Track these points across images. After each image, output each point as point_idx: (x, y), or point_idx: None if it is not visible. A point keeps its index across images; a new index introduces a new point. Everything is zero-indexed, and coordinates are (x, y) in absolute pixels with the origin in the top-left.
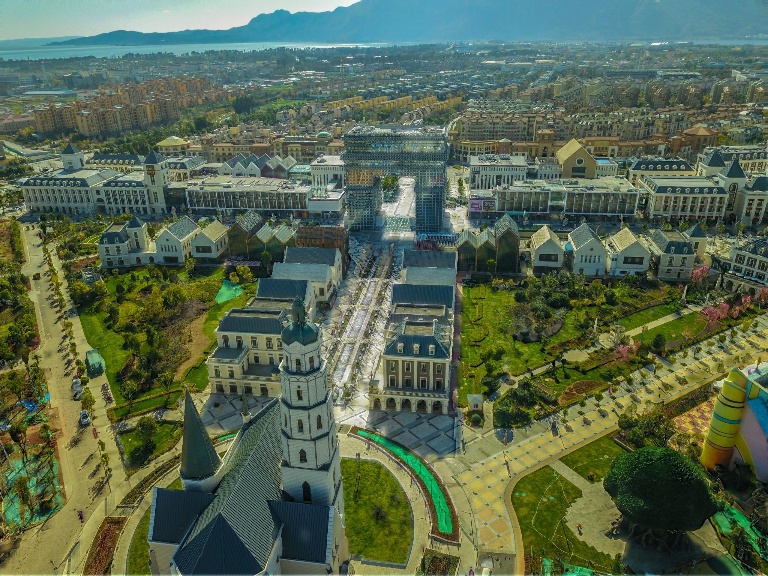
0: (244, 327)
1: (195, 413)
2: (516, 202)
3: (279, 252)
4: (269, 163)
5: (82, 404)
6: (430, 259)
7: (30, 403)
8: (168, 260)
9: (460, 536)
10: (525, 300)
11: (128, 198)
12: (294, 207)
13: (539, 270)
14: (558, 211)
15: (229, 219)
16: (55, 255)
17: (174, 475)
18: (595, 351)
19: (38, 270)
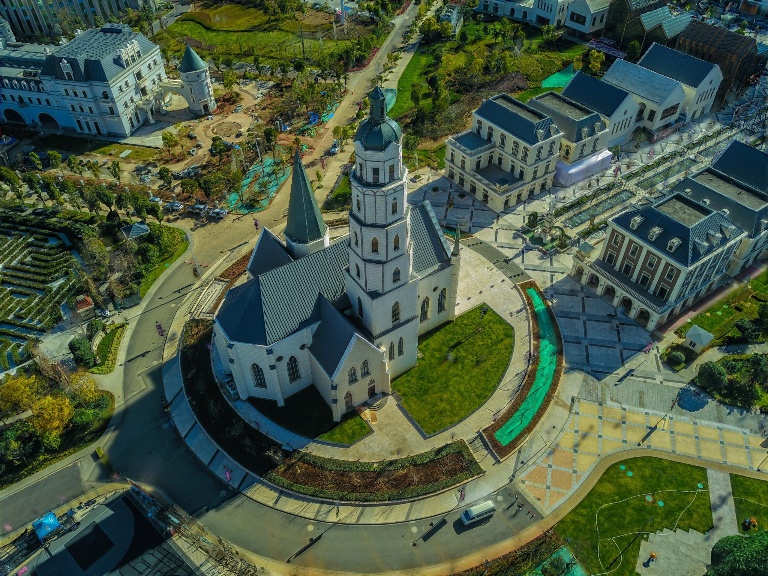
0: (499, 119)
1: (300, 176)
2: None
3: None
4: None
5: (334, 134)
6: None
7: (315, 116)
8: (540, 21)
9: (509, 455)
10: None
11: None
12: None
13: None
14: None
15: None
16: None
17: (344, 231)
18: None
19: None
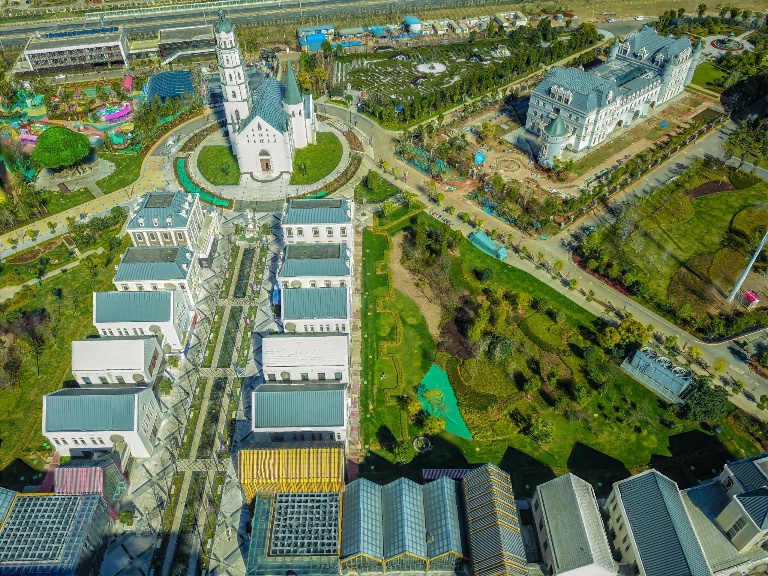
0: None
1: None
2: None
3: None
4: None
5: None
6: (97, 392)
7: None
8: None
9: None
10: None
11: None
12: None
13: None
14: None
15: None
16: None
17: (340, 169)
18: None
19: None
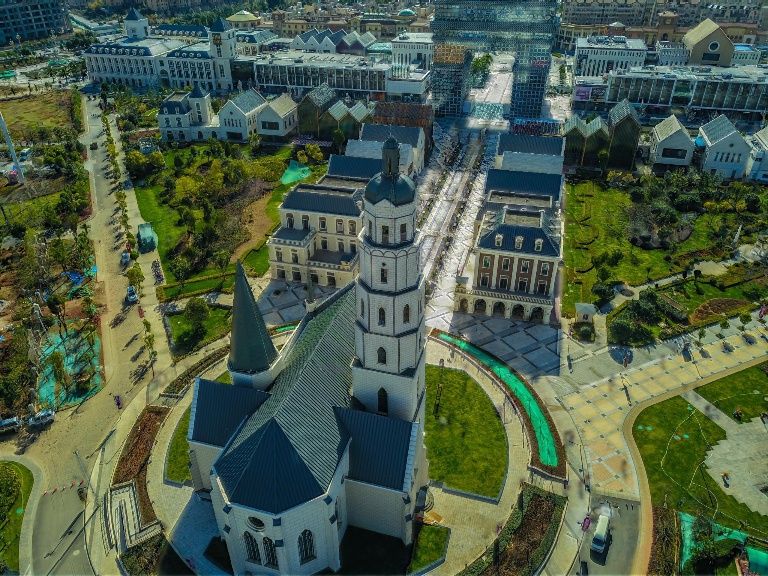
0: (312, 205)
1: (247, 291)
2: (632, 90)
3: (353, 132)
4: (345, 39)
5: (129, 279)
6: (531, 145)
7: (76, 275)
8: (232, 137)
9: (568, 471)
10: (643, 200)
11: (193, 71)
12: (371, 88)
13: (660, 168)
14: (682, 104)
15: (299, 99)
16: (115, 126)
17: (225, 366)
18: (736, 264)
19: (96, 140)
